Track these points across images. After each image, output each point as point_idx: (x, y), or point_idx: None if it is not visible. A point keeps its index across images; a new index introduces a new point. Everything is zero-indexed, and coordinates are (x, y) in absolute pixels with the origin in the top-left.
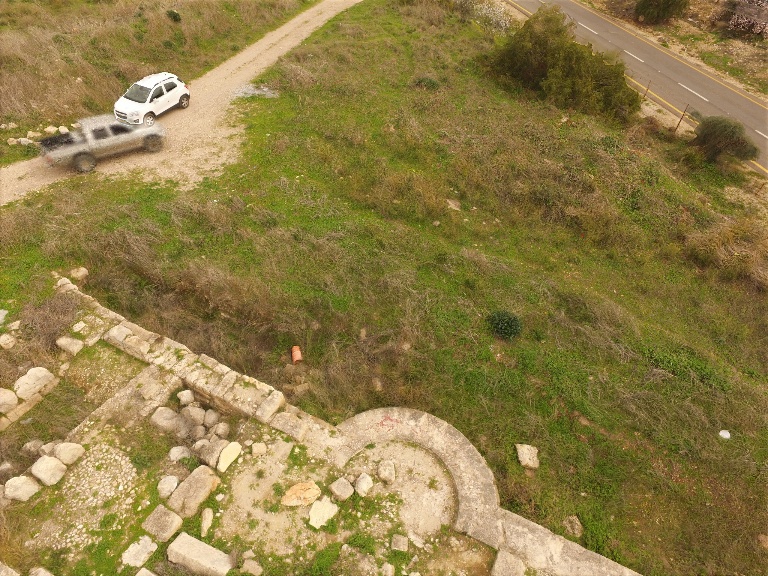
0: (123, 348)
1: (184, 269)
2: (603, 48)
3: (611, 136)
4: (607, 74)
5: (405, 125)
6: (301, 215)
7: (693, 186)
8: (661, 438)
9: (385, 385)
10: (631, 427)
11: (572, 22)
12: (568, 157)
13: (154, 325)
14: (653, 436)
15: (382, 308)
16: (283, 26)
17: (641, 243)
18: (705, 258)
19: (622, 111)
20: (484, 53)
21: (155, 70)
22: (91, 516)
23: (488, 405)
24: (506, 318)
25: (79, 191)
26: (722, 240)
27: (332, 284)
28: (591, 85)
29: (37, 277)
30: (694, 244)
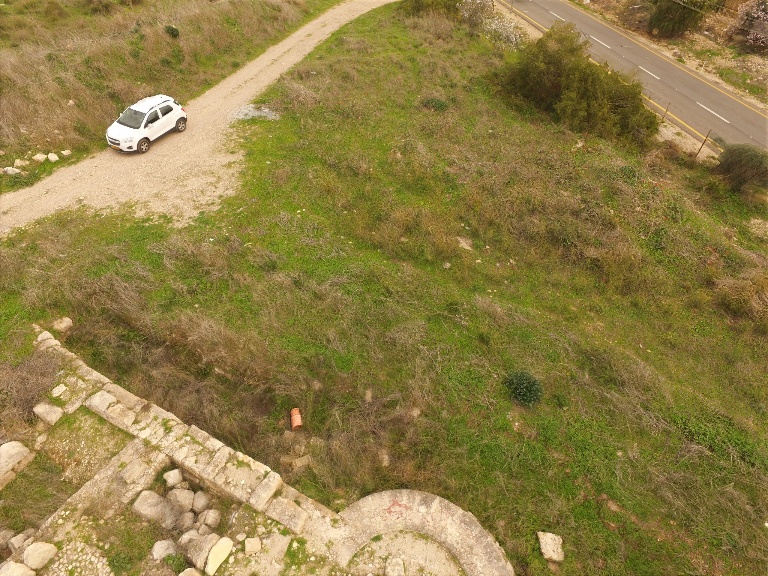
0: (106, 417)
1: (175, 320)
2: (617, 64)
3: (630, 164)
4: (623, 95)
5: (412, 151)
6: (302, 256)
7: (717, 218)
8: (701, 531)
9: (393, 459)
10: (666, 515)
11: (587, 40)
12: (585, 189)
13: (142, 385)
14: (692, 528)
15: (389, 367)
16: (285, 40)
17: (667, 288)
18: (738, 308)
19: (639, 134)
20: (494, 70)
21: (151, 91)
22: None
23: (506, 484)
24: (525, 382)
25: (66, 228)
26: (756, 288)
27: (335, 339)
28: (607, 106)
29: (16, 332)
30: (725, 292)
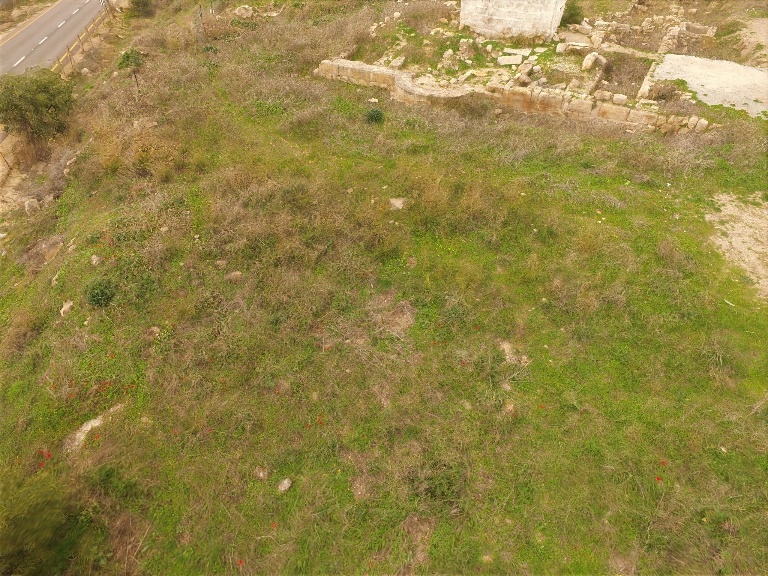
0: None
1: None
2: None
3: None
4: None
5: None
6: None
7: None
8: None
9: (450, 110)
10: None
11: None
12: None
13: None
14: None
15: None
16: None
17: None
18: None
19: None
20: None
21: None
22: (559, 61)
23: None
24: (374, 111)
25: None
26: None
27: None
28: None
29: None
30: (175, 157)
